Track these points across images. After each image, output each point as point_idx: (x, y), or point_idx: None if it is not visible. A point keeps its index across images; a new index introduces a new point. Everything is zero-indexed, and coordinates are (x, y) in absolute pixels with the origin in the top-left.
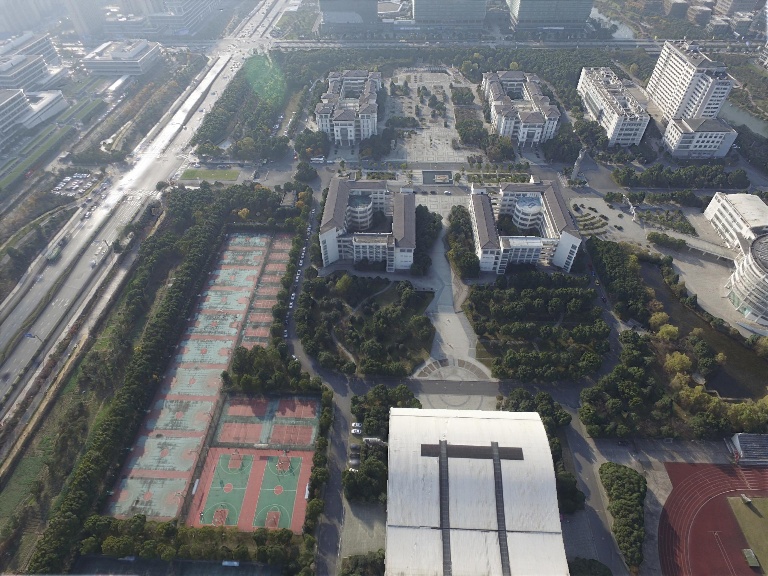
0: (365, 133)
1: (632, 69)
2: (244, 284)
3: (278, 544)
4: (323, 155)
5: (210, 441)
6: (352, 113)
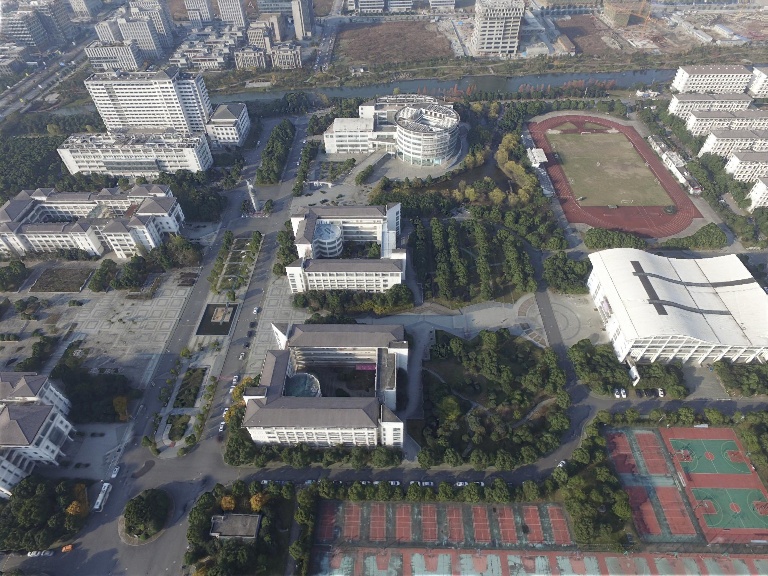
0: (60, 407)
1: (55, 130)
2: (446, 571)
3: (760, 439)
4: (86, 488)
5: (702, 545)
6: (22, 409)
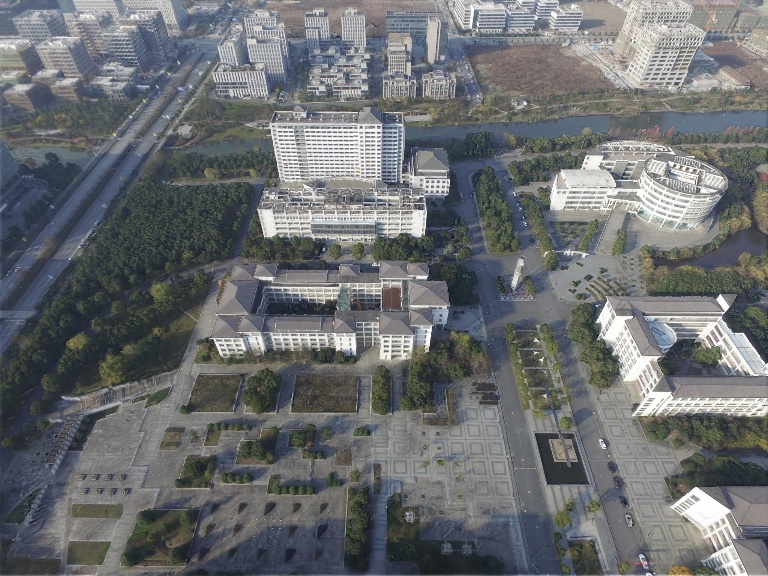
0: None
1: (216, 175)
2: None
3: None
4: None
5: None
6: None
